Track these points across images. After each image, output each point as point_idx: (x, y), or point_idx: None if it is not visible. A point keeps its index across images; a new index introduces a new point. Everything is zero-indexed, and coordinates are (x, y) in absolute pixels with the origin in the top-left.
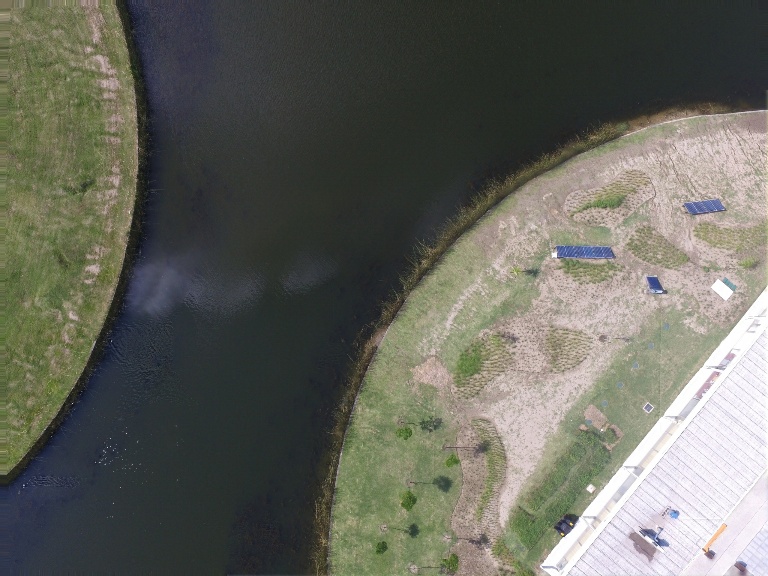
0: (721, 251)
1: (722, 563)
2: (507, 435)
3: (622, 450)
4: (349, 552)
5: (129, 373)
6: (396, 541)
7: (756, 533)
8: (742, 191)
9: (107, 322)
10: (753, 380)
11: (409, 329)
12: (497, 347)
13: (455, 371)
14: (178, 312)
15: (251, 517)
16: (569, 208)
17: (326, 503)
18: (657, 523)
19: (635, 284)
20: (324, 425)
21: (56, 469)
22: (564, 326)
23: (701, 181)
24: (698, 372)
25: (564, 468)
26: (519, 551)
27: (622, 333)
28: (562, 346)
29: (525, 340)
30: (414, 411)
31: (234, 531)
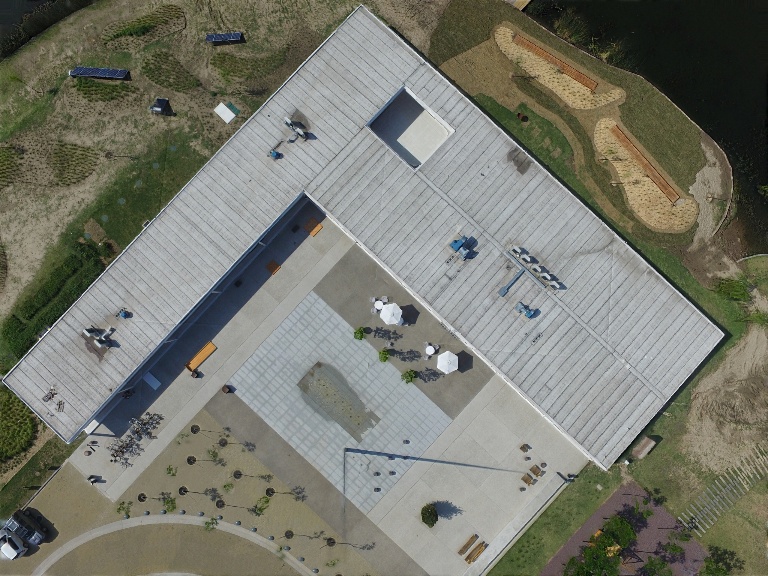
0: (233, 79)
1: (211, 385)
2: (10, 245)
3: None
4: None
5: None
6: None
7: (247, 358)
8: (265, 26)
9: None
10: (216, 188)
11: None
12: (6, 158)
13: None
14: None
15: None
16: (105, 37)
17: None
18: (110, 323)
19: (146, 106)
20: None
21: None
22: (73, 142)
23: (230, 16)
24: None
25: (57, 278)
26: (10, 359)
27: (129, 151)
28: (70, 161)
29: (33, 152)
30: None
31: None
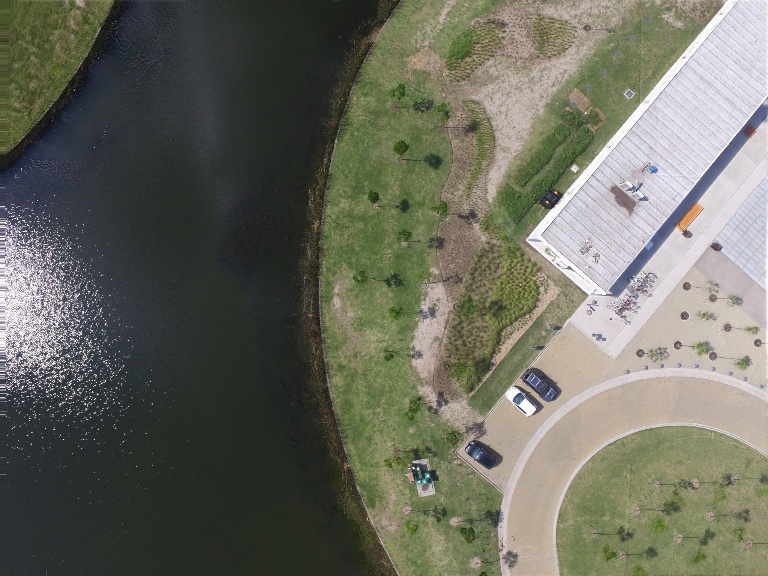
0: None
1: (699, 244)
2: (496, 116)
3: (604, 132)
4: (341, 234)
5: (132, 63)
6: (387, 217)
7: (731, 217)
8: None
9: (113, 10)
10: (726, 49)
11: (404, 24)
12: (487, 32)
13: (447, 55)
14: (182, 7)
15: (246, 204)
16: None
17: (320, 189)
18: (637, 179)
19: None
20: (320, 116)
21: (55, 153)
22: (551, 16)
23: None
24: (676, 62)
25: (549, 146)
26: (506, 226)
27: (605, 24)
28: (549, 34)
29: (514, 26)
30: (407, 95)
31: (228, 218)
